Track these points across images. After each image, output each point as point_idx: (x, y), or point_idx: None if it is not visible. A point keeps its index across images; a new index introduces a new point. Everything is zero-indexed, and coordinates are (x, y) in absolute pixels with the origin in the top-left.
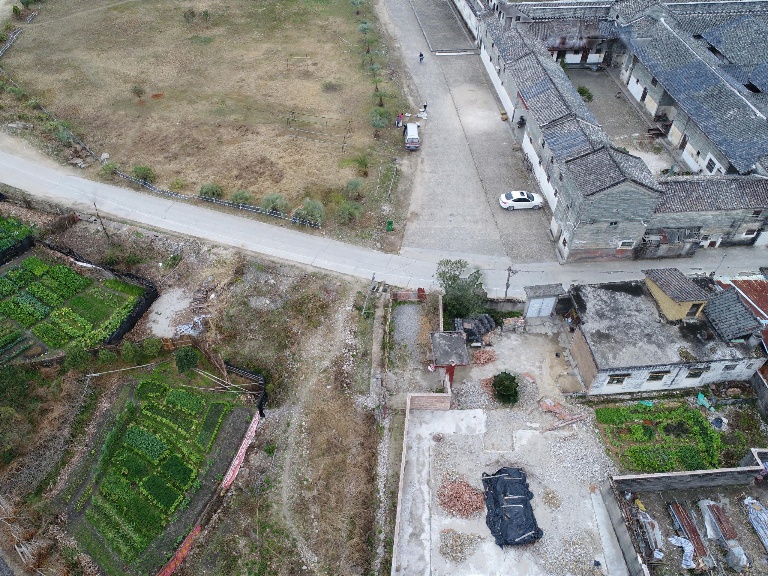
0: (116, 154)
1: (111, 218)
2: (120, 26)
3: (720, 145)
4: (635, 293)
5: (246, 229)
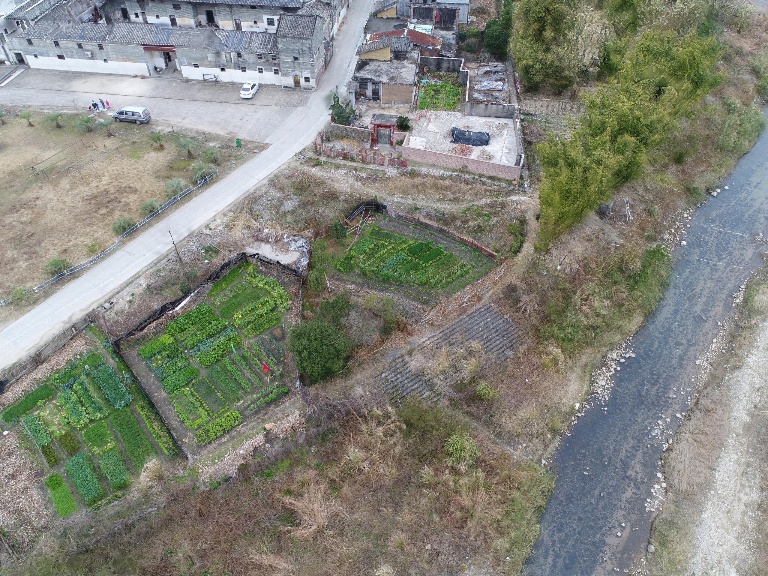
0: None
1: (116, 292)
2: None
3: (273, 4)
4: (367, 64)
5: (195, 208)
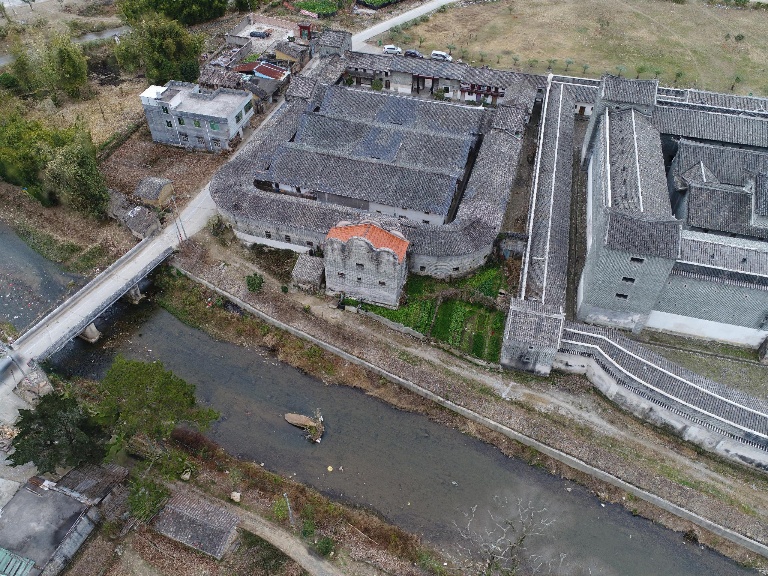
0: (466, 8)
1: (421, 5)
2: (607, 14)
3: None
4: None
5: None
